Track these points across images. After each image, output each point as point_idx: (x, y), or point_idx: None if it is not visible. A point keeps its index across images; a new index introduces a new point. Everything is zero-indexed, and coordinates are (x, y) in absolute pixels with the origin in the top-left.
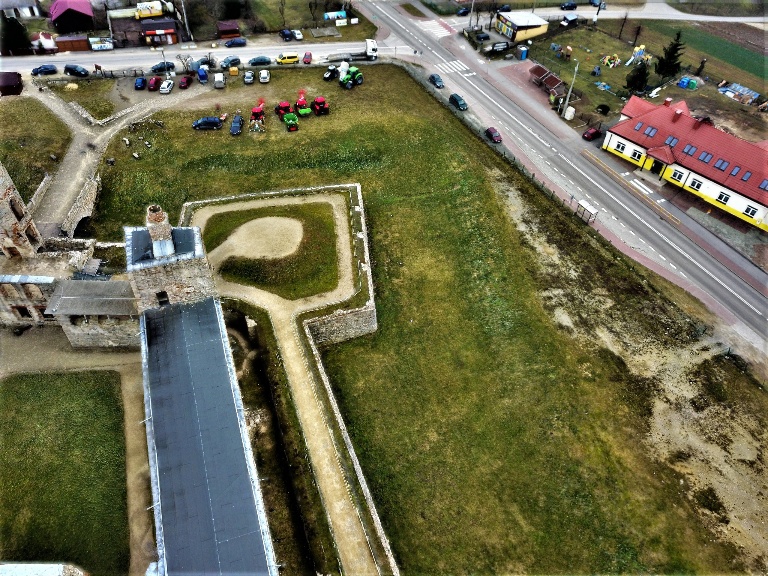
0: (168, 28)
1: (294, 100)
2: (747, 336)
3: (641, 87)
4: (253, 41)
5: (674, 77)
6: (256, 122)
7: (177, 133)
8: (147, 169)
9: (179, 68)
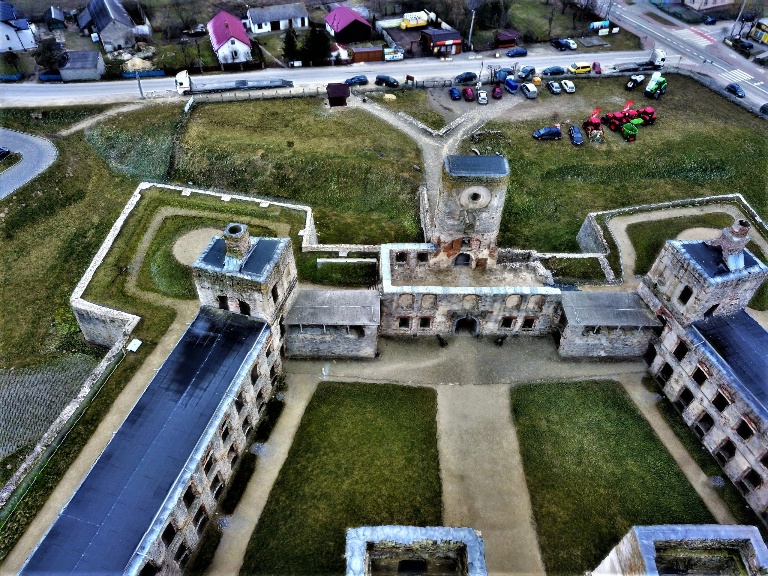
0: (456, 38)
1: (611, 110)
2: None
3: None
4: (530, 51)
5: None
6: (599, 132)
7: (522, 143)
8: (510, 179)
9: (480, 78)
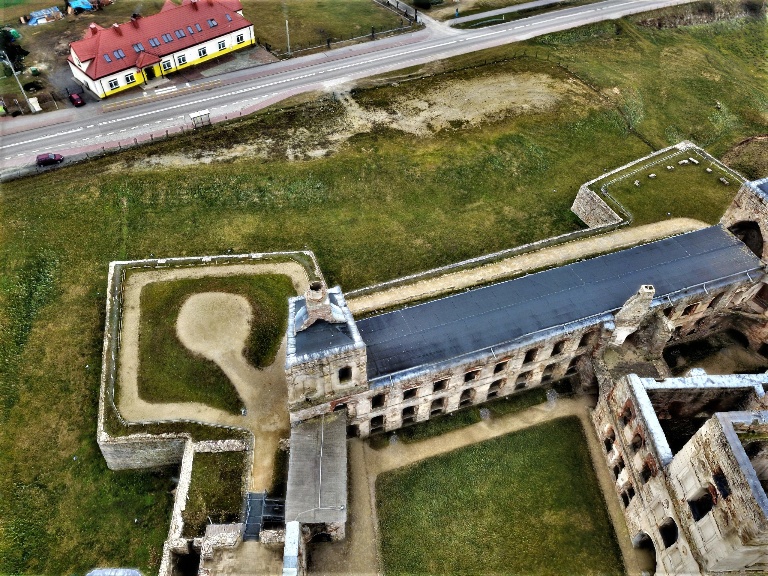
0: None
1: None
2: (334, 83)
3: (23, 51)
4: None
5: None
6: None
7: None
8: None
9: None
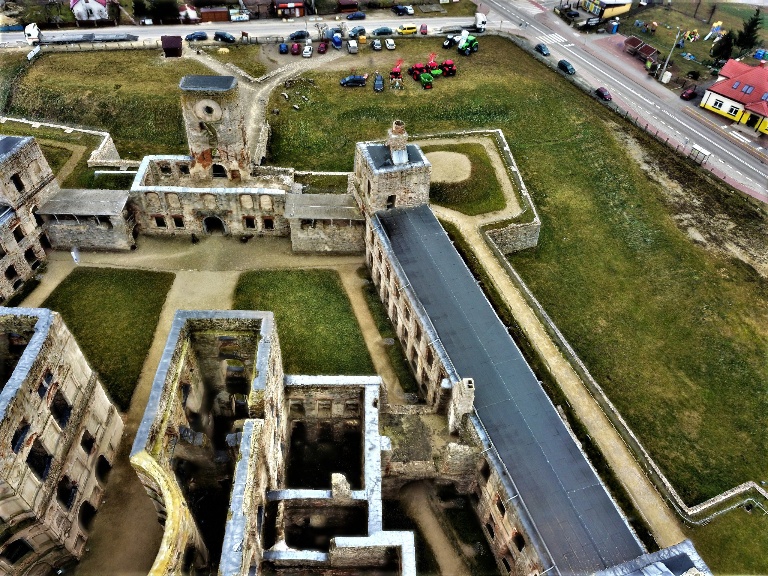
0: (298, 2)
1: None
2: None
3: (727, 56)
4: (370, 15)
5: (750, 50)
6: (397, 80)
7: (328, 89)
8: (309, 118)
9: (313, 36)
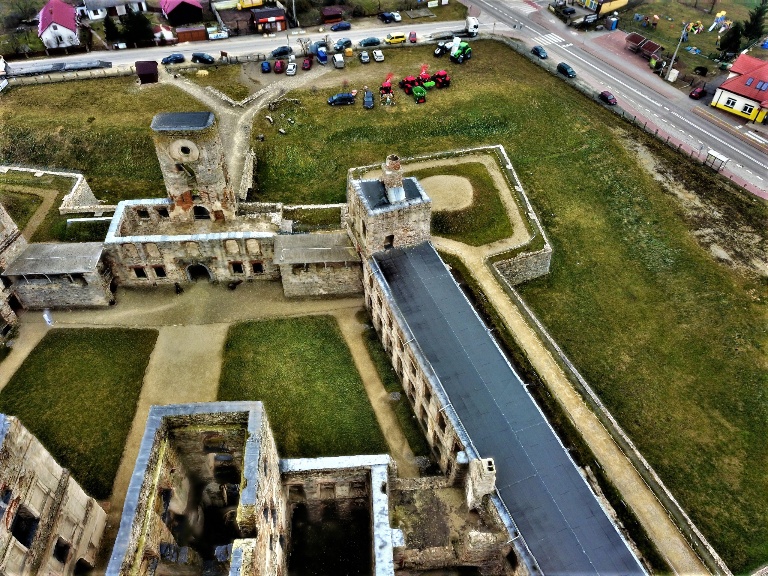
0: (278, 15)
1: (412, 75)
2: None
3: (736, 48)
4: (355, 24)
5: (758, 39)
6: (388, 96)
7: (315, 109)
8: (296, 143)
9: (296, 52)
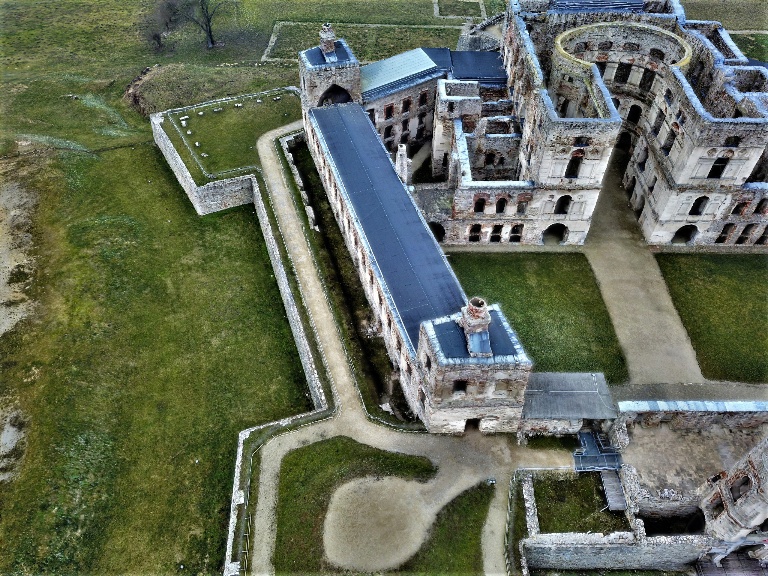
0: None
1: None
2: None
3: None
4: None
5: None
6: None
7: None
8: None
9: None
